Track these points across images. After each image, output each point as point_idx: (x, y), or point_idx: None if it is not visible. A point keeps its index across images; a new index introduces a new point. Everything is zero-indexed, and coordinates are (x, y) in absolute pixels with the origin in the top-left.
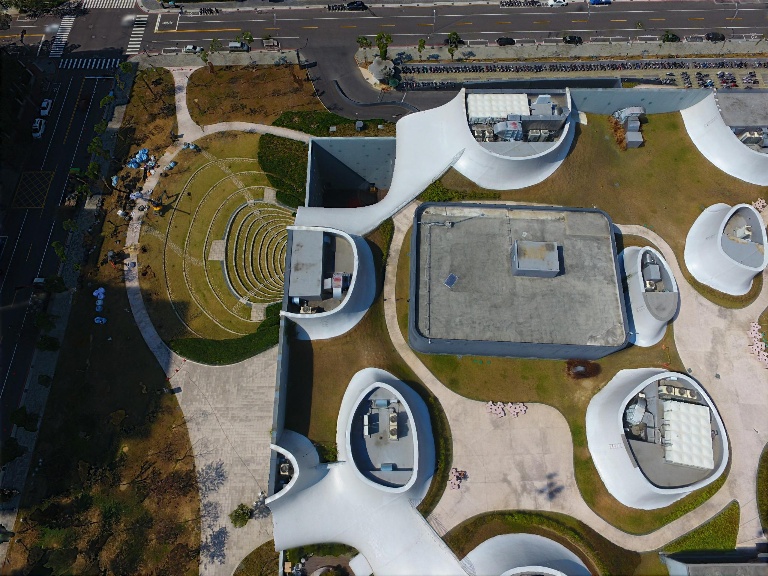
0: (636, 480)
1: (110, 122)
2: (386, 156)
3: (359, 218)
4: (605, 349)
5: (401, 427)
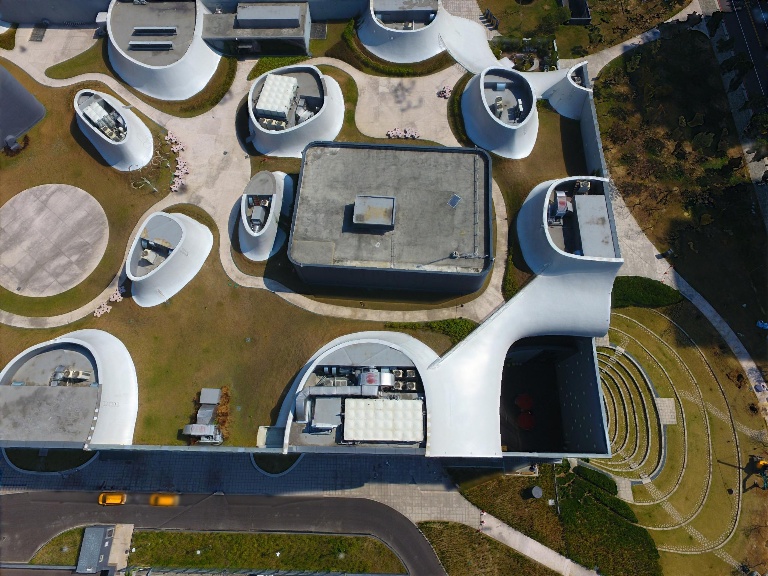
0: None
1: None
2: None
3: (541, 303)
4: (327, 141)
5: None
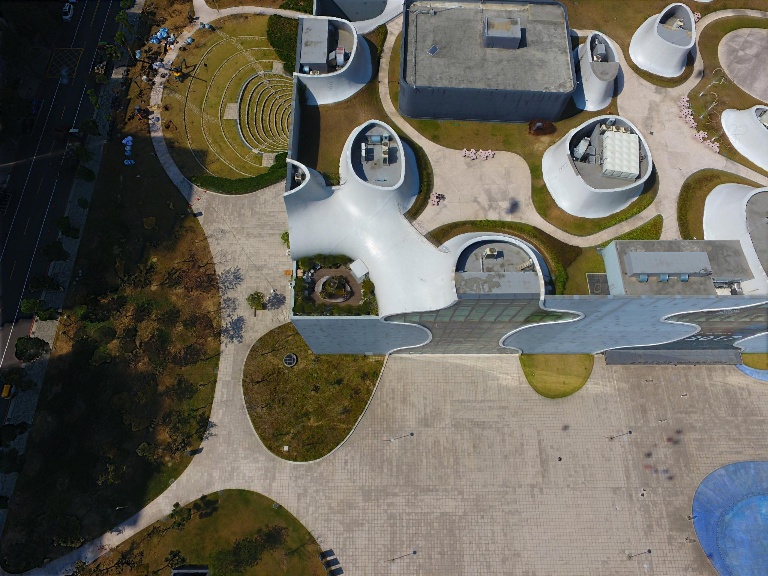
0: (578, 186)
1: (132, 8)
2: (382, 4)
3: (358, 25)
4: (556, 94)
5: (392, 157)
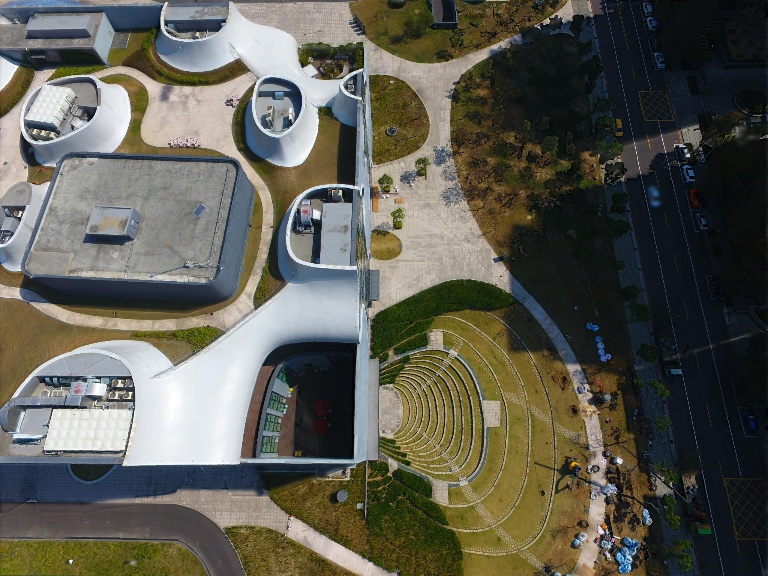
0: (103, 85)
1: None
2: None
3: (290, 311)
4: (84, 152)
5: None
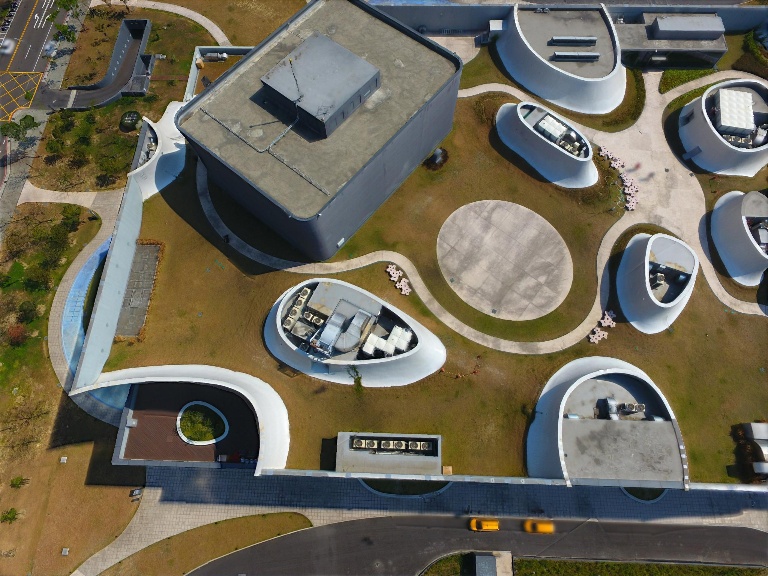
0: None
1: None
2: None
3: None
4: None
5: None
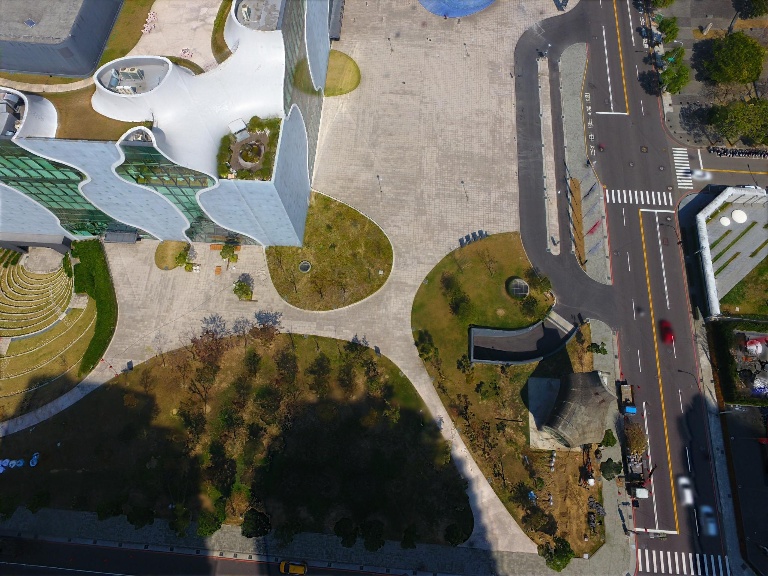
0: None
1: None
2: None
3: None
4: None
5: None
